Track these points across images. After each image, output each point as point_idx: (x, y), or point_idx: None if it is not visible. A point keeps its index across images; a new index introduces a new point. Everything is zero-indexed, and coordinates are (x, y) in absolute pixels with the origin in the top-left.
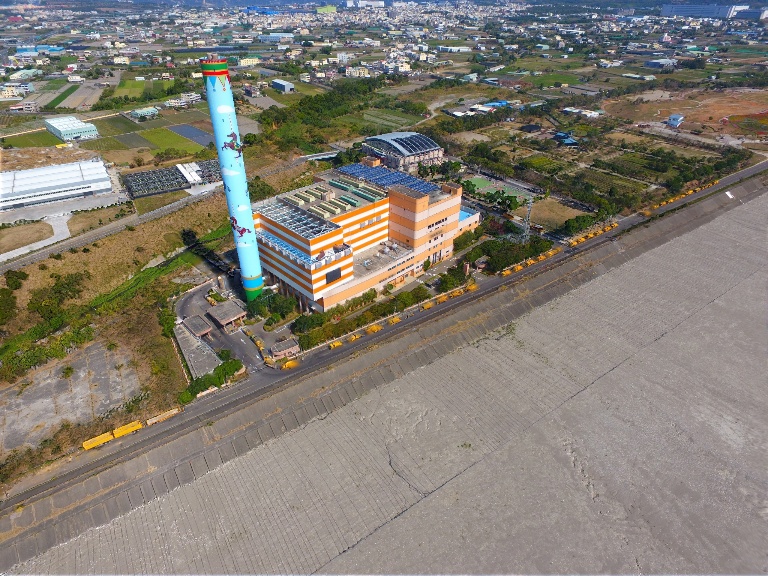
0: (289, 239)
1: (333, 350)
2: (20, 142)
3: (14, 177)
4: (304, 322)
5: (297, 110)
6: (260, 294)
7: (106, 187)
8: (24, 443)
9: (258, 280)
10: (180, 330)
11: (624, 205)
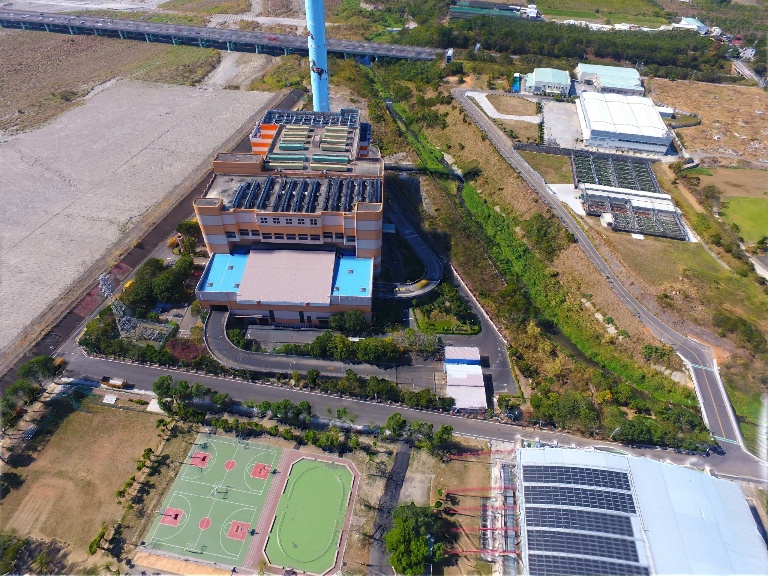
0: None
1: None
2: None
3: (635, 103)
4: None
5: None
6: None
7: (586, 136)
8: None
9: None
10: None
11: None
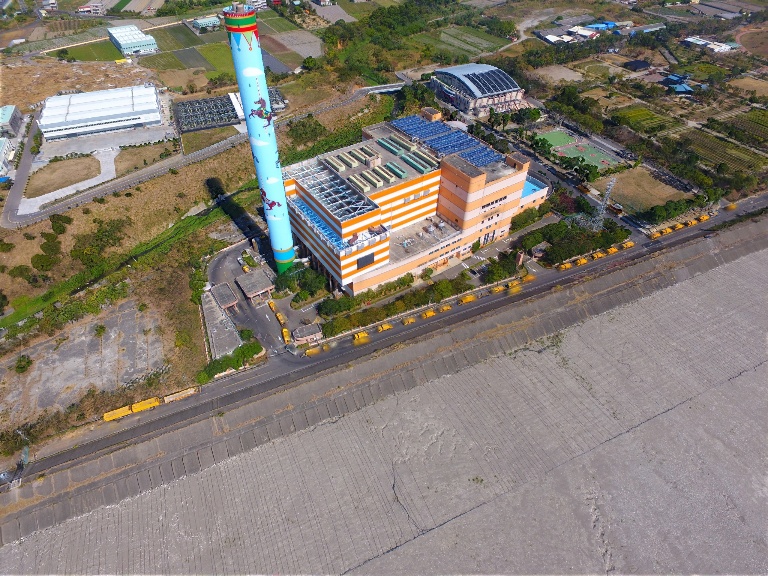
0: (322, 215)
1: (357, 342)
2: (83, 54)
3: (69, 102)
4: (330, 308)
5: (367, 25)
6: (290, 267)
7: (155, 119)
8: (54, 404)
9: (289, 253)
10: (207, 298)
11: (733, 187)
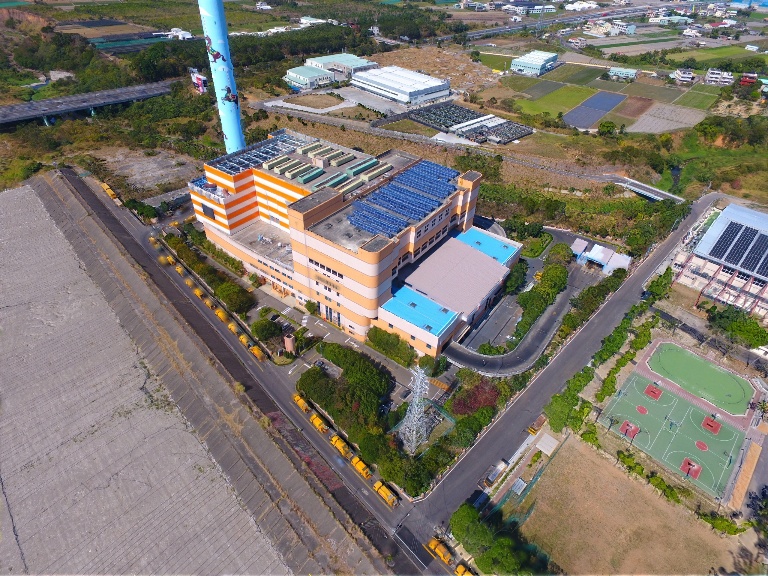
0: None
1: None
2: (494, 61)
3: (393, 71)
4: None
5: None
6: None
7: (404, 100)
8: (120, 170)
9: None
10: None
11: None
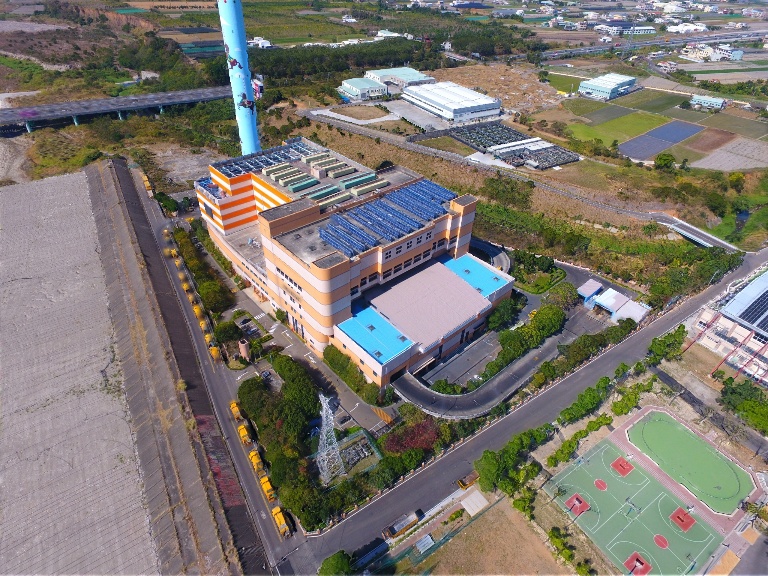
0: None
1: None
2: (564, 82)
3: (447, 87)
4: None
5: None
6: None
7: (448, 117)
8: (165, 165)
9: None
10: None
11: None
